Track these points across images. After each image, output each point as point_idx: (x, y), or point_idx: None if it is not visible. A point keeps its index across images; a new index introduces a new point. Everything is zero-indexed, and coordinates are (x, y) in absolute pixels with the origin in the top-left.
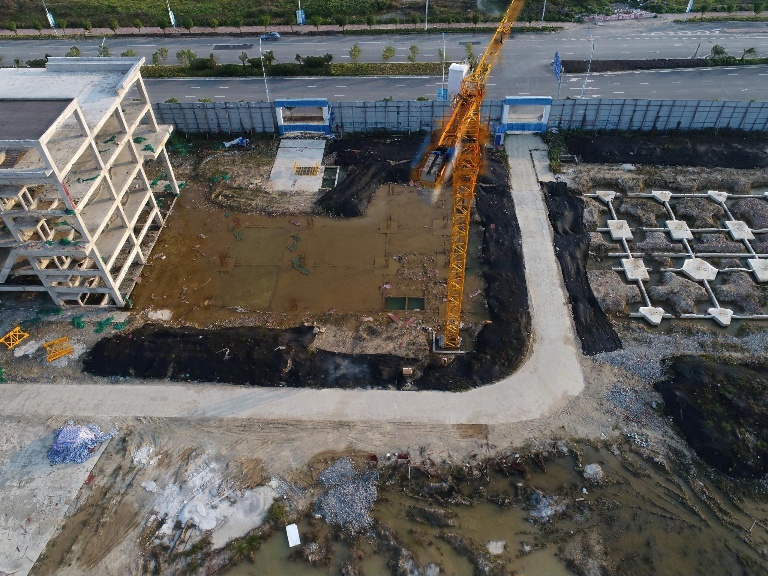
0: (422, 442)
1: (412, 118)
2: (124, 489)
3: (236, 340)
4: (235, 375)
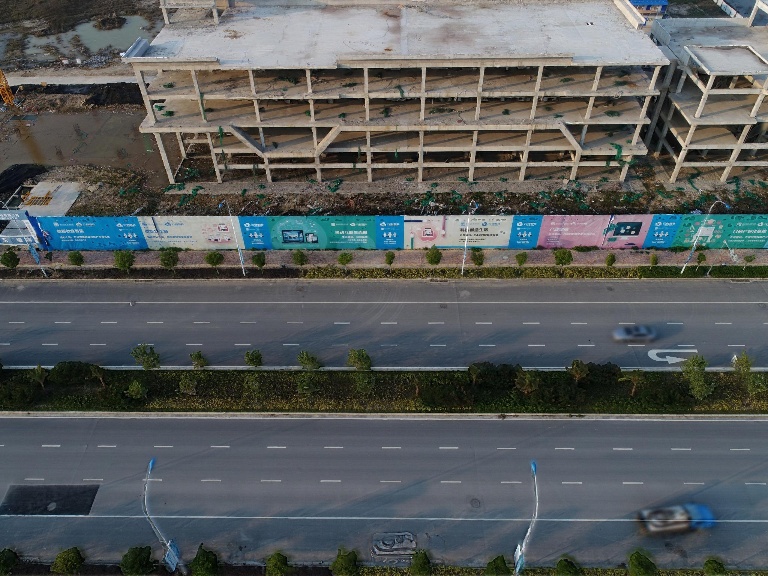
0: None
1: None
2: None
3: None
4: None
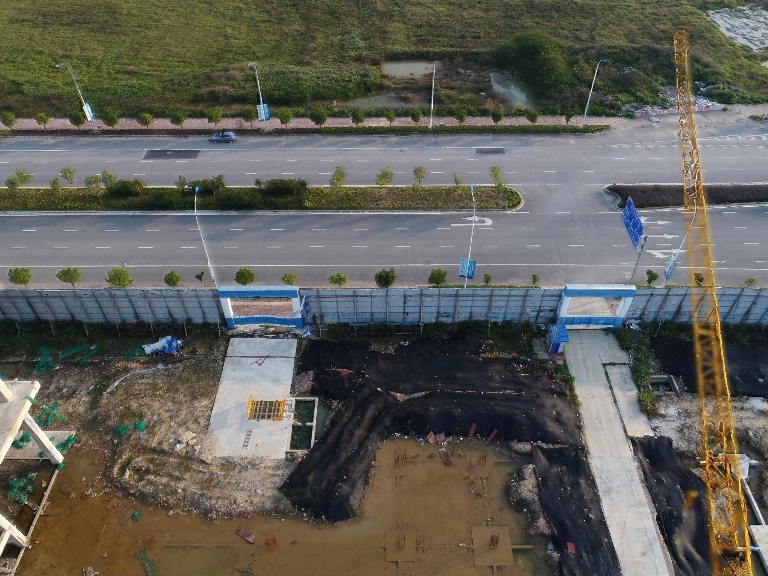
0: None
1: (426, 308)
2: None
3: None
4: None
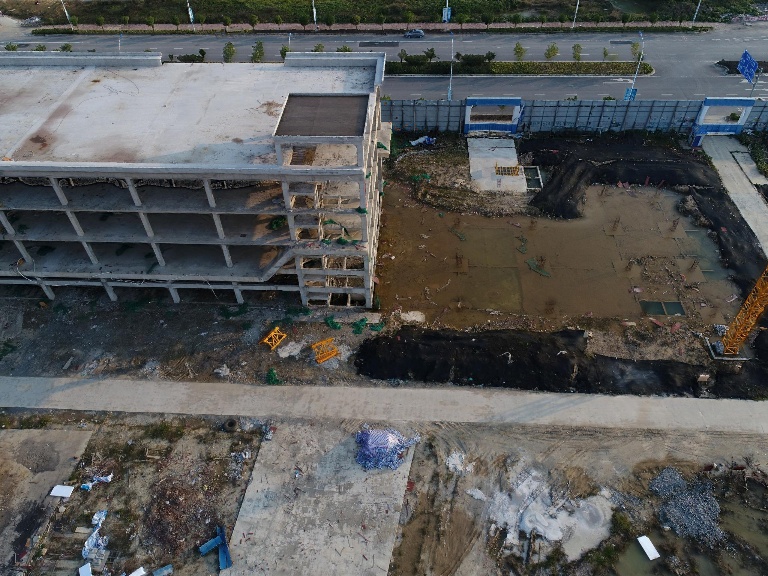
0: (744, 452)
1: (603, 118)
2: (450, 497)
3: (514, 344)
4: (522, 380)
